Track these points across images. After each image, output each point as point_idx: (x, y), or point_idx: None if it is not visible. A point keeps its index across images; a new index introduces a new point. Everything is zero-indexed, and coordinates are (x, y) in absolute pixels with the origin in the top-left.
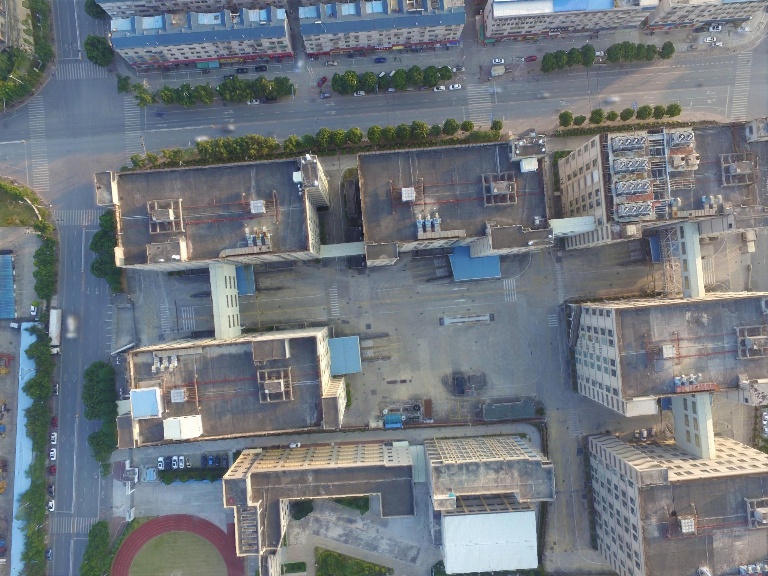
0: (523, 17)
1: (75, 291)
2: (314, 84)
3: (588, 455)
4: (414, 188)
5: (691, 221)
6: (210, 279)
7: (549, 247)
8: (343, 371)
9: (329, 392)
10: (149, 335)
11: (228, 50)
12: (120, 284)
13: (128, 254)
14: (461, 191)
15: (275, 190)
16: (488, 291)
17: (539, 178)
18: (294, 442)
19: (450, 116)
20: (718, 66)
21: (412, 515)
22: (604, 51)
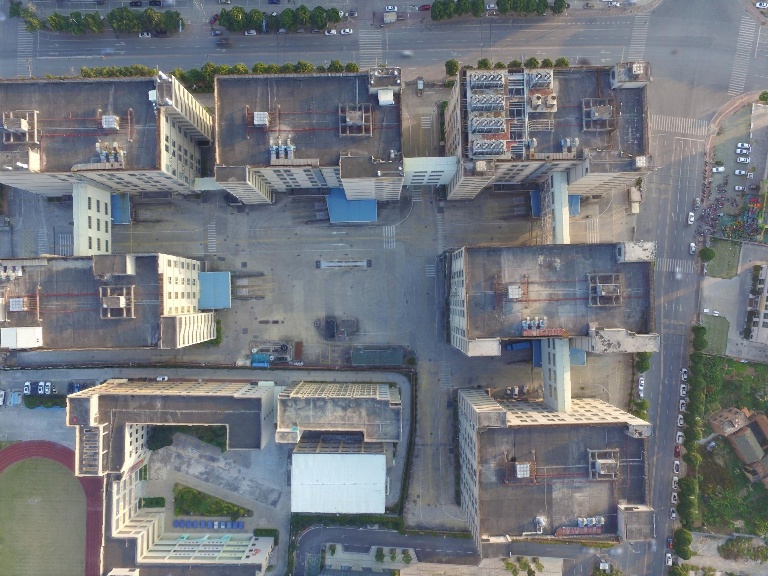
0: None
1: None
2: (206, 21)
3: (457, 408)
4: (270, 114)
5: (549, 164)
6: None
7: (431, 197)
8: (212, 306)
9: None
10: None
11: None
12: None
13: None
14: (318, 120)
15: (132, 108)
16: (367, 237)
17: (397, 112)
18: (161, 375)
19: (340, 60)
20: (614, 26)
21: (258, 449)
22: None
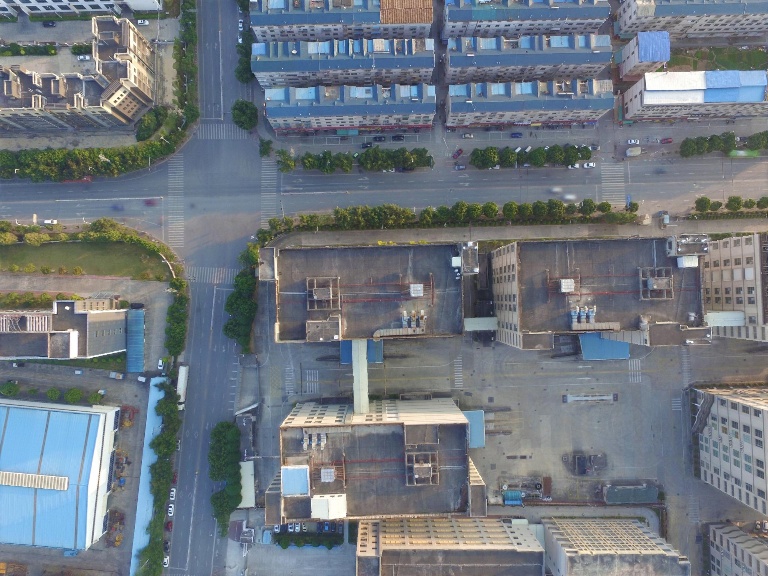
0: (671, 105)
1: (202, 348)
2: (449, 155)
3: (708, 544)
4: (570, 278)
5: None
6: (352, 352)
7: None
8: None
9: (471, 476)
10: (273, 396)
11: (373, 121)
12: None
13: (283, 329)
14: (617, 283)
15: (432, 273)
16: (613, 371)
17: (695, 274)
18: None
19: (583, 194)
20: None
21: None
22: (740, 137)
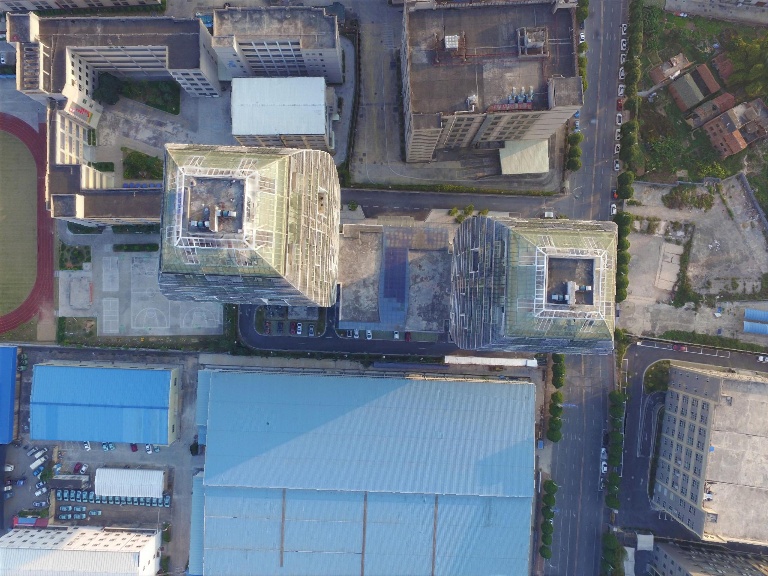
0: None
1: None
2: None
3: (400, 66)
4: None
5: None
6: None
7: None
8: None
9: None
10: None
11: None
12: None
13: None
14: None
15: None
16: None
17: None
18: None
19: None
20: None
21: (197, 68)
22: None
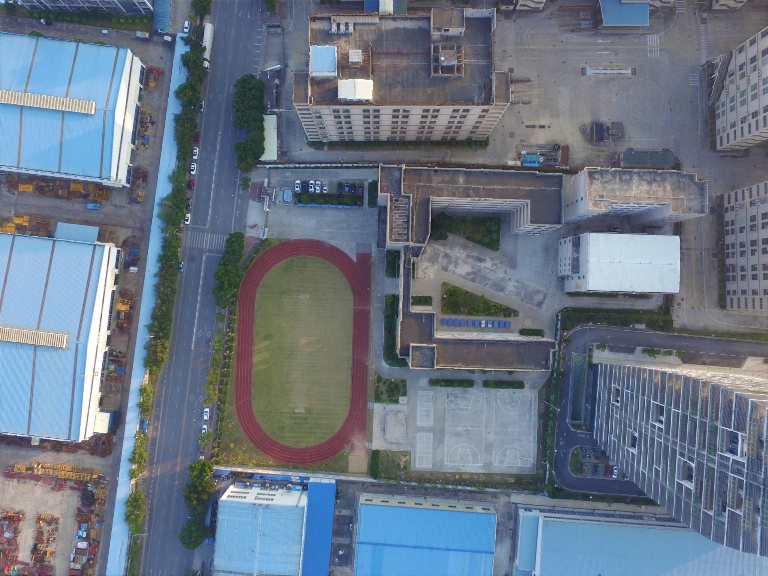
0: None
1: (228, 13)
2: None
3: (722, 213)
4: None
5: None
6: None
7: (695, 8)
8: None
9: None
10: (296, 61)
11: None
12: None
13: None
14: None
15: None
16: (631, 46)
17: None
18: None
19: None
20: None
21: (560, 224)
22: None
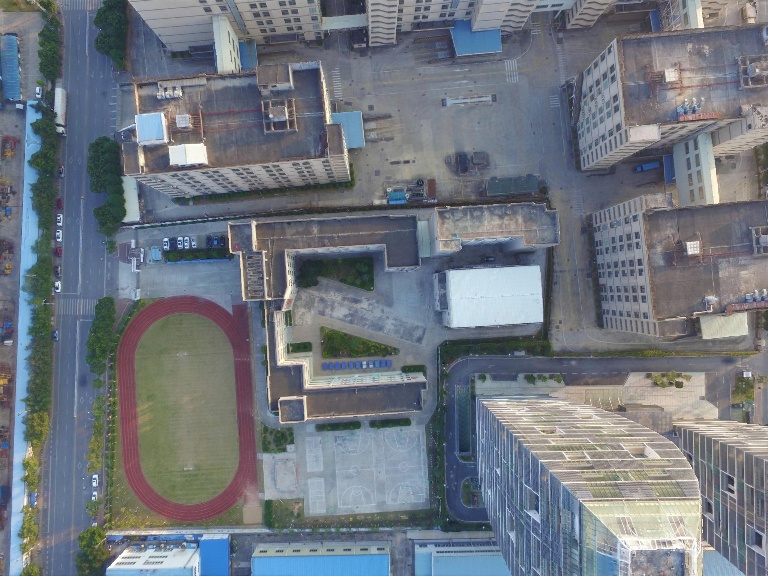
0: None
1: (80, 75)
2: None
3: (592, 233)
4: None
5: None
6: None
7: (550, 28)
8: (346, 145)
9: None
10: None
11: None
12: (124, 65)
13: None
14: None
15: None
16: (490, 72)
17: None
18: None
19: None
20: None
21: (417, 265)
22: None
